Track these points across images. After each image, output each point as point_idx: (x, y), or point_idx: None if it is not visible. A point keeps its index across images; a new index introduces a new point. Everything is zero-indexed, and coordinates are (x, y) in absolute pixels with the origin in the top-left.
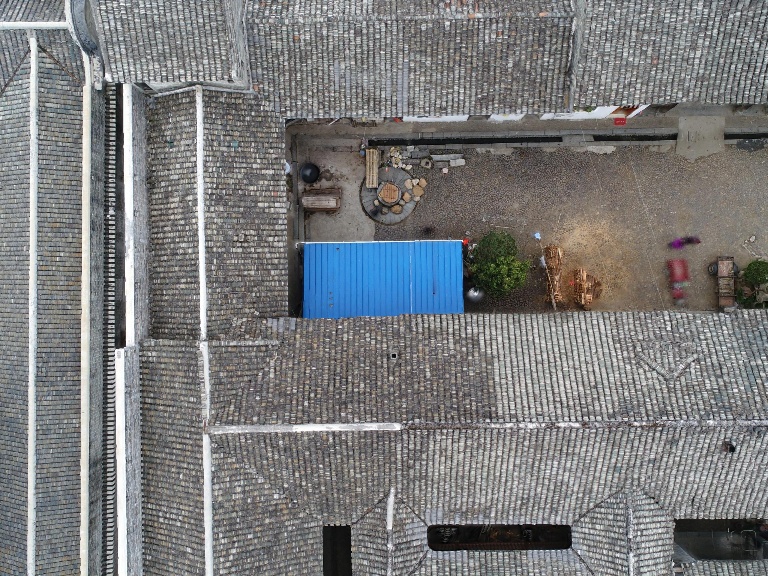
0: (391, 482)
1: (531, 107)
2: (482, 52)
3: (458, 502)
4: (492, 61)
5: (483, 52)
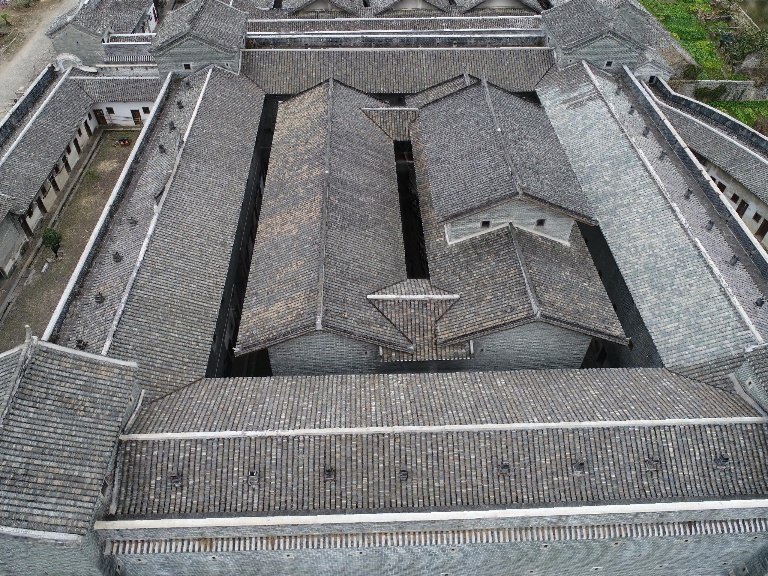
0: (254, 7)
1: (146, 4)
2: (124, 3)
3: (264, 3)
4: (128, 3)
5: (124, 3)
